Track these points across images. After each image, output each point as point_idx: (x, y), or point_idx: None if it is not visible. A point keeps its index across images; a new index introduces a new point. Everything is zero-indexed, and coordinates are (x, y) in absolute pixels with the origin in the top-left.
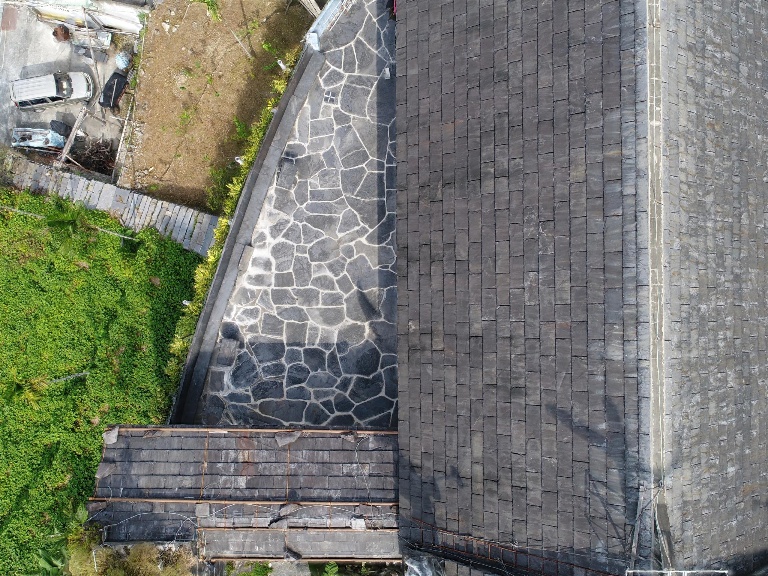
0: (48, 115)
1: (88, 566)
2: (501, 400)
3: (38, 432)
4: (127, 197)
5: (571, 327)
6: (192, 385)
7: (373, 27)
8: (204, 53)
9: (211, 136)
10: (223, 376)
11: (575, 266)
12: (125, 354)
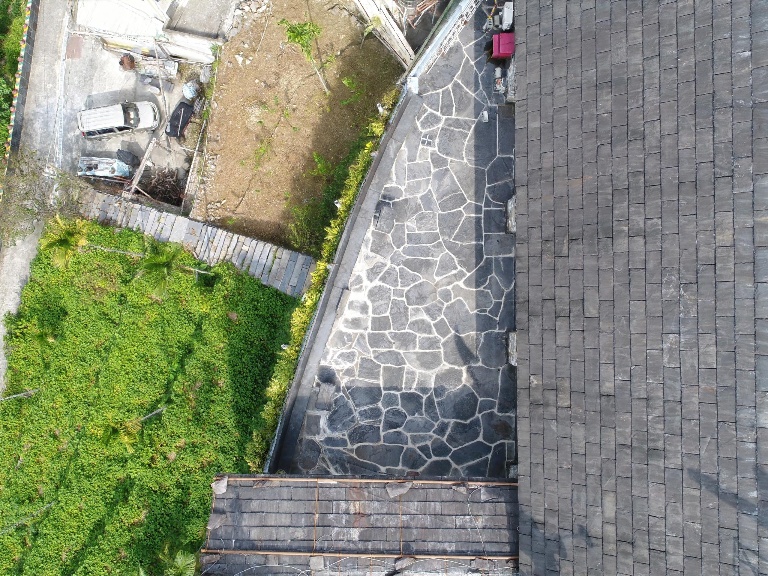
0: (113, 144)
1: None
2: (636, 461)
3: (111, 466)
4: (200, 230)
5: (717, 392)
6: (289, 429)
7: (471, 70)
8: (277, 86)
9: (285, 169)
10: (319, 420)
11: (722, 331)
12: (202, 389)
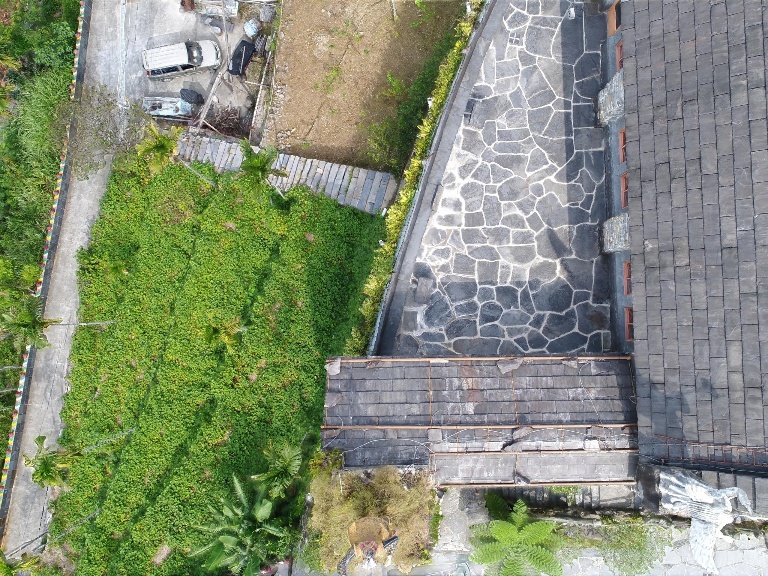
0: (175, 85)
1: (335, 489)
2: (763, 307)
3: (191, 391)
4: None
5: None
6: (388, 324)
7: None
8: (344, 14)
9: (355, 95)
10: (416, 316)
11: None
12: (282, 310)
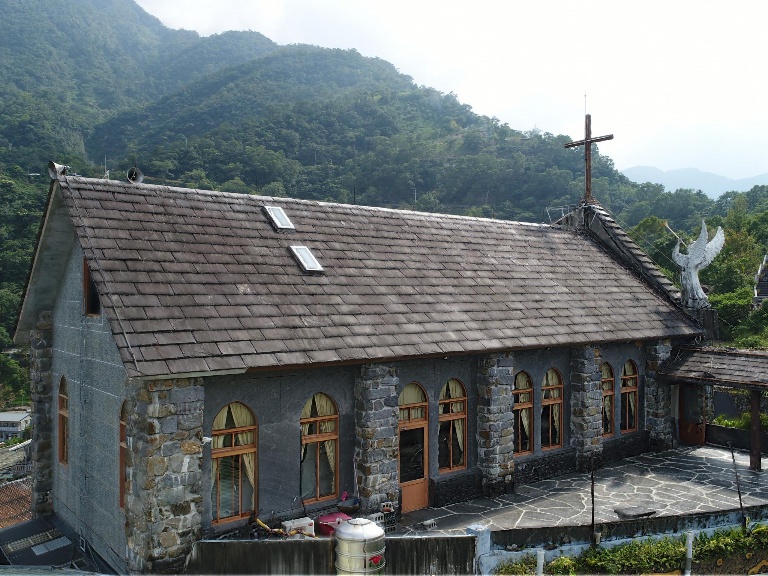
0: None
1: None
2: None
3: None
4: None
5: (520, 246)
6: None
7: None
8: None
9: None
10: None
11: None
12: None
